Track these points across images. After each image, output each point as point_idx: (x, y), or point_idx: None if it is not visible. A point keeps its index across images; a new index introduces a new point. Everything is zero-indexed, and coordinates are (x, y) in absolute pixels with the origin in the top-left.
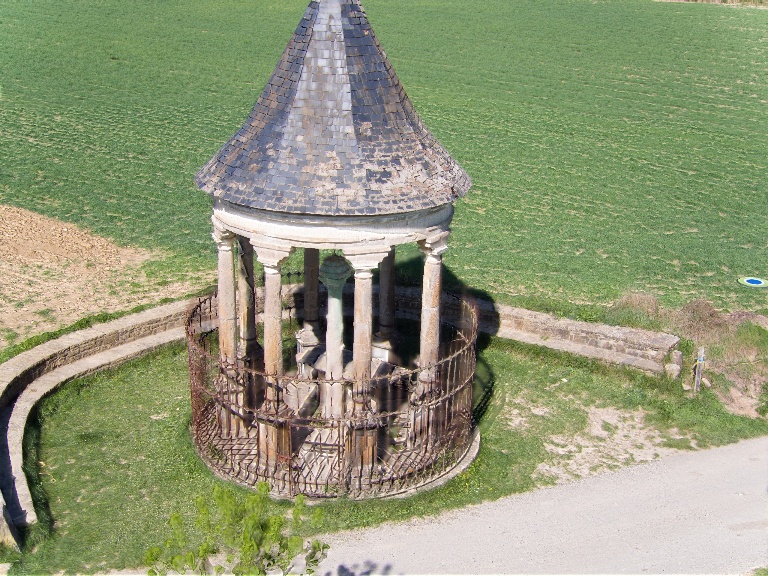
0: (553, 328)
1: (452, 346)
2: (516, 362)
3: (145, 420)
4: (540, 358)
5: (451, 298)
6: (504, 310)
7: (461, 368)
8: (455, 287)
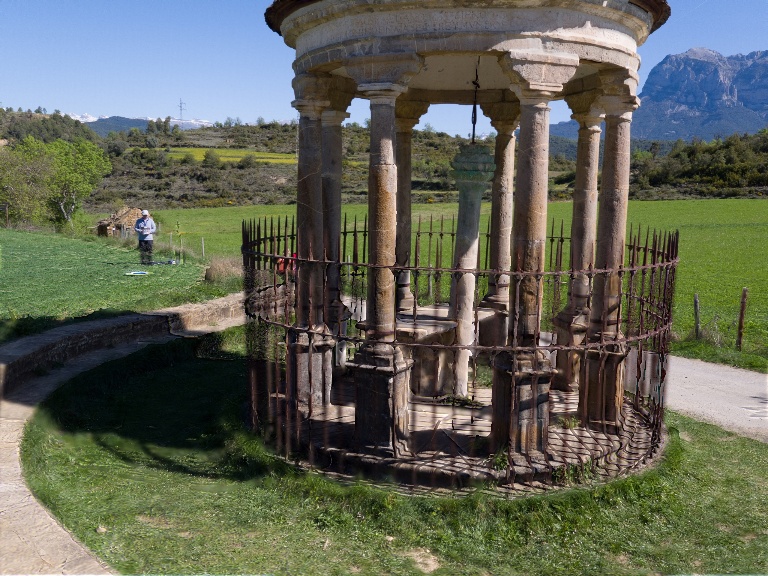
0: (218, 310)
1: (182, 365)
2: (234, 351)
3: (453, 575)
4: (245, 337)
5: (106, 323)
6: (165, 313)
7: (245, 368)
8: (76, 317)
